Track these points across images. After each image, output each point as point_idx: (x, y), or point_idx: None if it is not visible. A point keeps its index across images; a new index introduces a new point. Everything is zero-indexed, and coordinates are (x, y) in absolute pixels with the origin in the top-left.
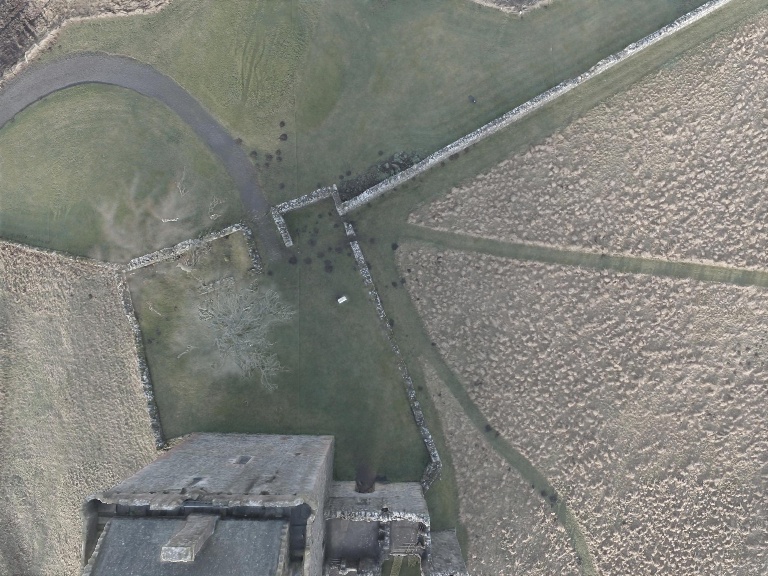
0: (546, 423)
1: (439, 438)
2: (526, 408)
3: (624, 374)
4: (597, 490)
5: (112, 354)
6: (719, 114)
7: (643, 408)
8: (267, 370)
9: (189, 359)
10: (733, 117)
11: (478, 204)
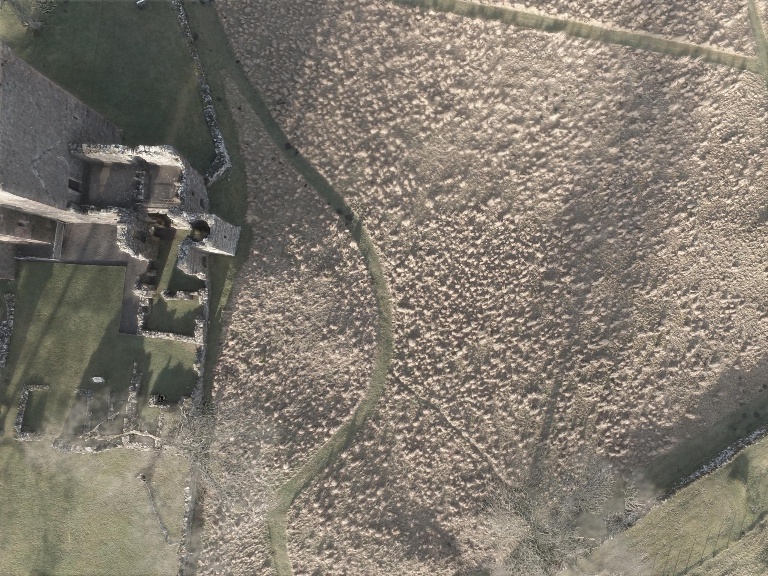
0: (347, 146)
1: (233, 146)
2: (328, 130)
3: (429, 106)
4: (394, 214)
5: None
6: None
7: (448, 143)
8: None
9: None
10: None
11: None
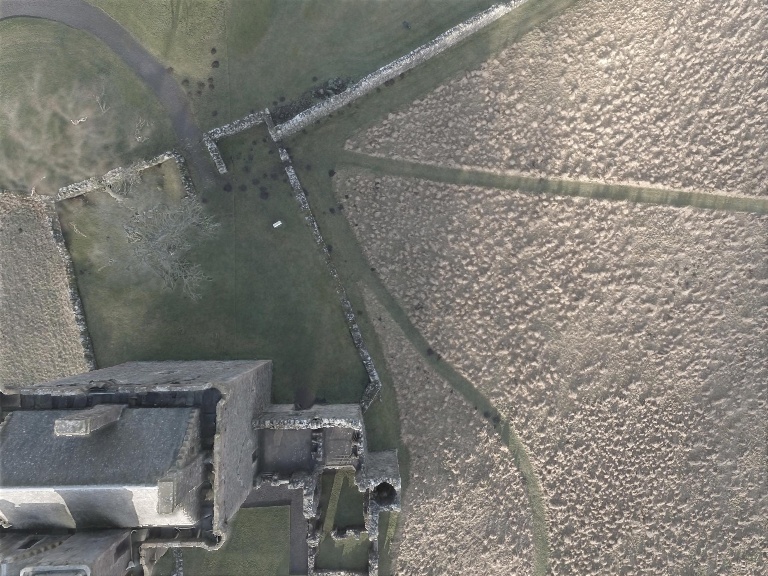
0: (488, 345)
1: (379, 361)
2: (467, 331)
3: (564, 295)
4: (540, 410)
5: (43, 287)
6: (652, 38)
7: (584, 329)
8: (189, 278)
9: (123, 289)
10: (666, 41)
11: (415, 130)
